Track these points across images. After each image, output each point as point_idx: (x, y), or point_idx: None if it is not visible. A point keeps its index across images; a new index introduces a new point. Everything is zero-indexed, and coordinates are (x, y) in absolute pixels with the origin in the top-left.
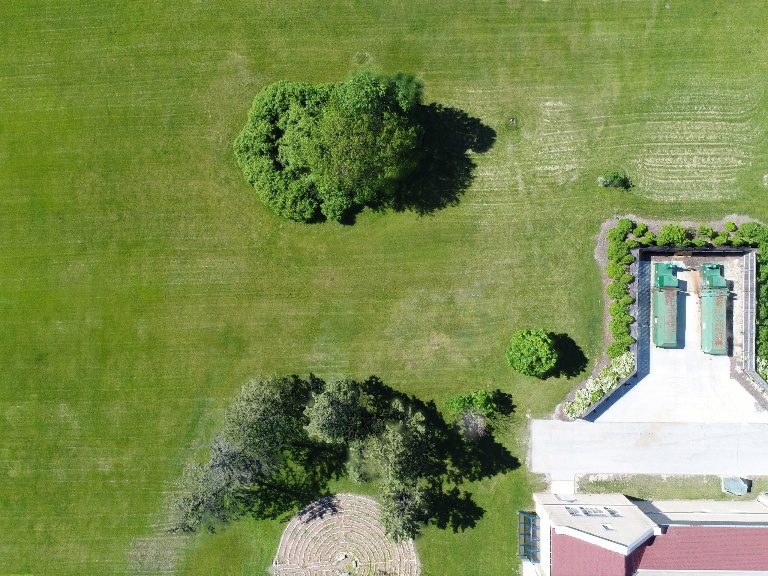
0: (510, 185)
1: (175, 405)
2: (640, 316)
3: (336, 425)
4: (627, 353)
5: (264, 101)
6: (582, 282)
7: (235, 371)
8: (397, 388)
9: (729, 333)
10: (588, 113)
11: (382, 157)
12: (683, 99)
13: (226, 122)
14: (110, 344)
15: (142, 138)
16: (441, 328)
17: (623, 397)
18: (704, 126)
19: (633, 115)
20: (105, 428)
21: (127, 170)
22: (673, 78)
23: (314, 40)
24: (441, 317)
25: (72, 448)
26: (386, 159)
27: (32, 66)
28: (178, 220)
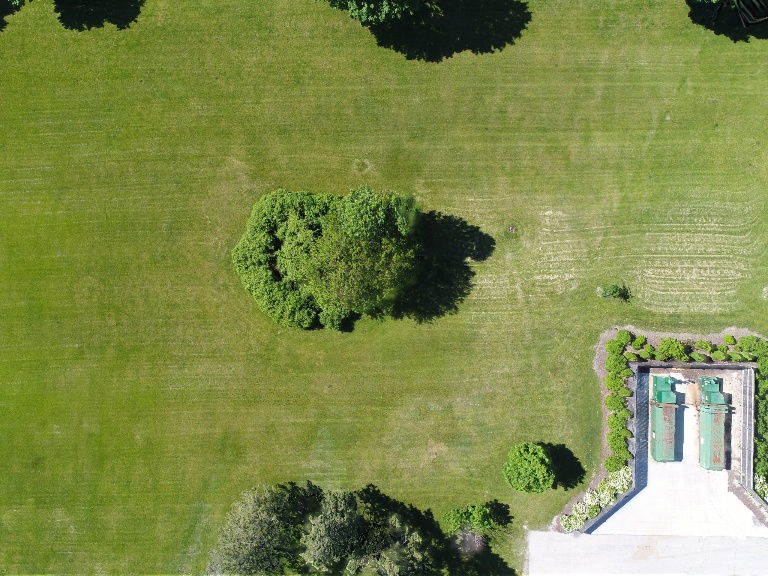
0: (509, 294)
1: (172, 511)
2: (638, 428)
3: (333, 543)
4: (625, 468)
5: (263, 212)
6: (580, 392)
7: (232, 477)
8: (394, 496)
9: (727, 446)
10: (588, 223)
11: (380, 281)
12: (683, 211)
13: (225, 228)
14: (107, 449)
15: (140, 243)
16: (439, 437)
17: (620, 509)
18: (704, 238)
19: (633, 226)
20: (102, 533)
21: (125, 275)
22: (673, 190)
23: (313, 147)
24: (439, 425)
25: (68, 553)
26: (384, 282)
27: (31, 170)
28: (176, 325)
